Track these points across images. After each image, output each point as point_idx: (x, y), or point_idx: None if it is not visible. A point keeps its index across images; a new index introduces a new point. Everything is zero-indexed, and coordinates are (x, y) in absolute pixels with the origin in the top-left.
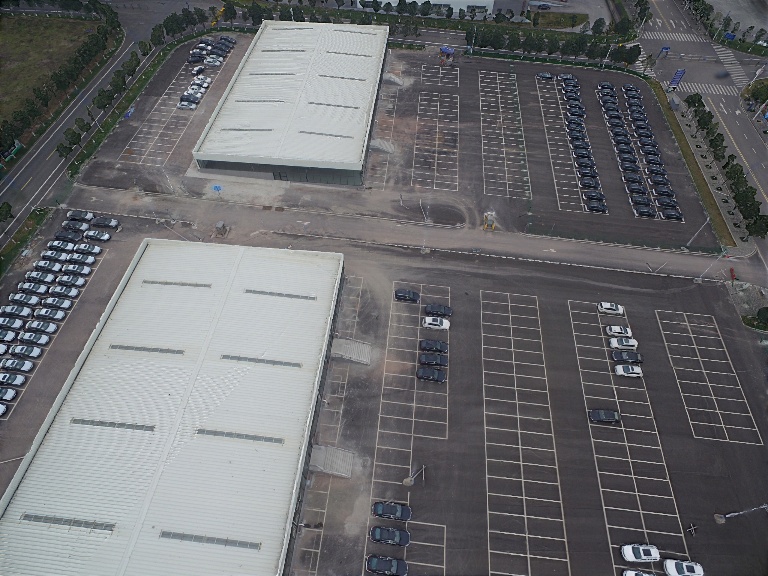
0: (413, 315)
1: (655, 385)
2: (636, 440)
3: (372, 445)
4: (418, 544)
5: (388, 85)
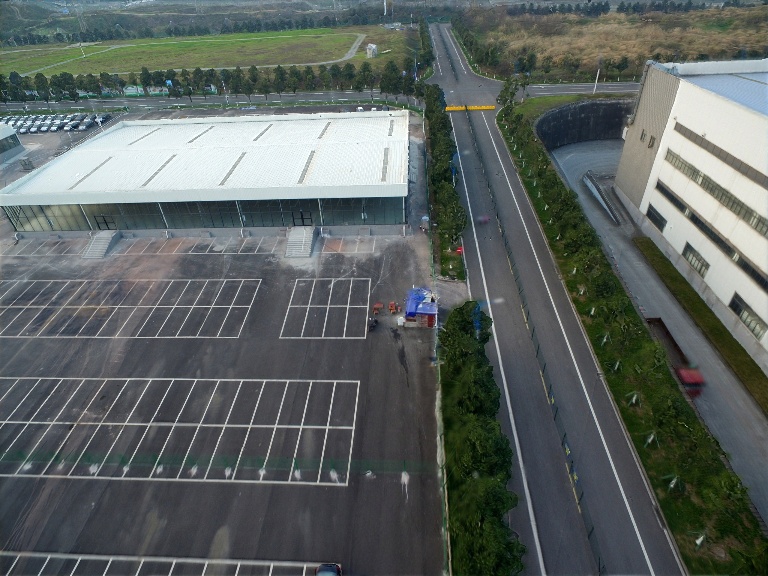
0: None
1: None
2: None
3: None
4: None
5: None
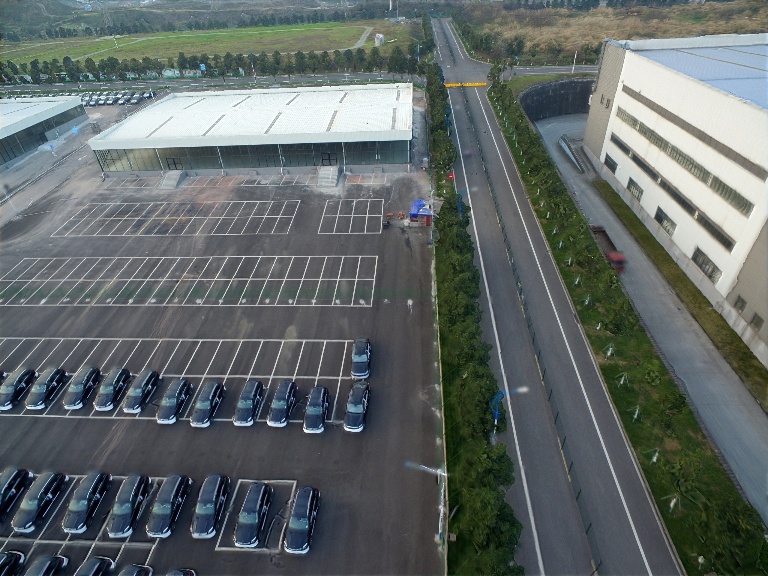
0: None
1: None
2: None
3: None
4: None
5: None
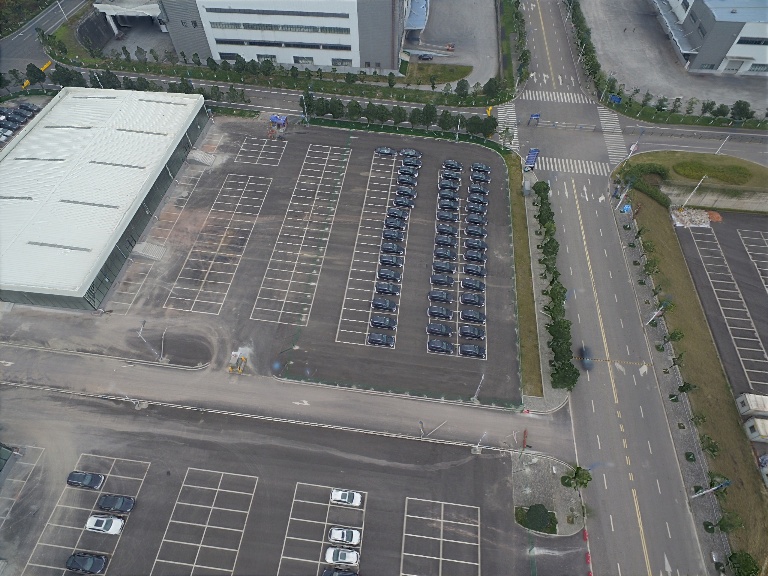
0: (84, 509)
1: None
2: None
3: None
4: None
5: (194, 165)
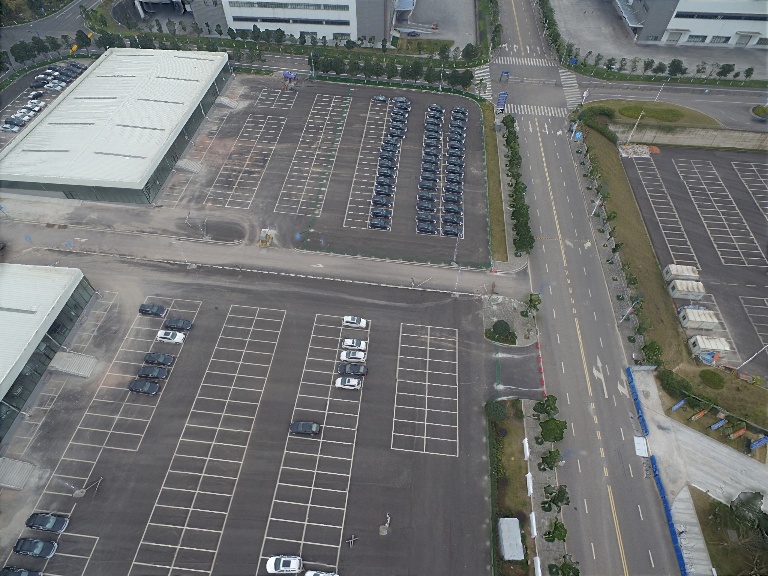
0: (153, 329)
1: (372, 397)
2: (330, 452)
3: (58, 457)
4: (63, 556)
5: (221, 108)
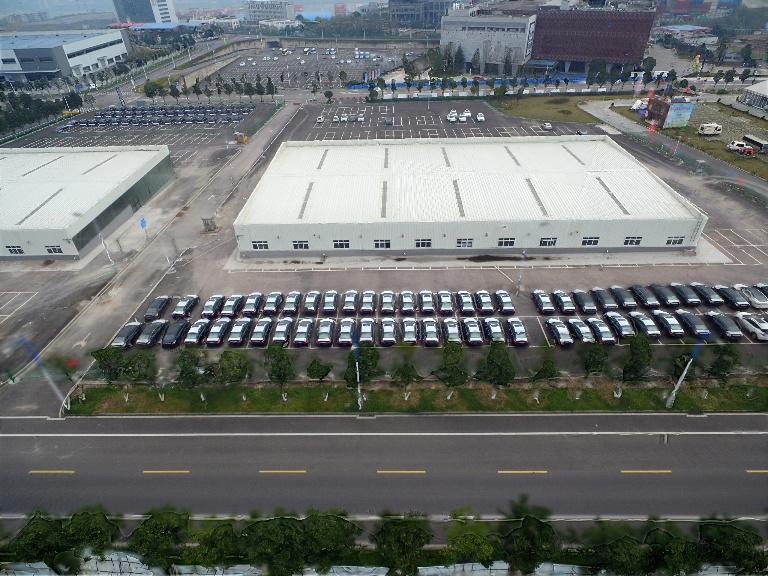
0: None
1: None
2: None
3: None
4: None
5: None
